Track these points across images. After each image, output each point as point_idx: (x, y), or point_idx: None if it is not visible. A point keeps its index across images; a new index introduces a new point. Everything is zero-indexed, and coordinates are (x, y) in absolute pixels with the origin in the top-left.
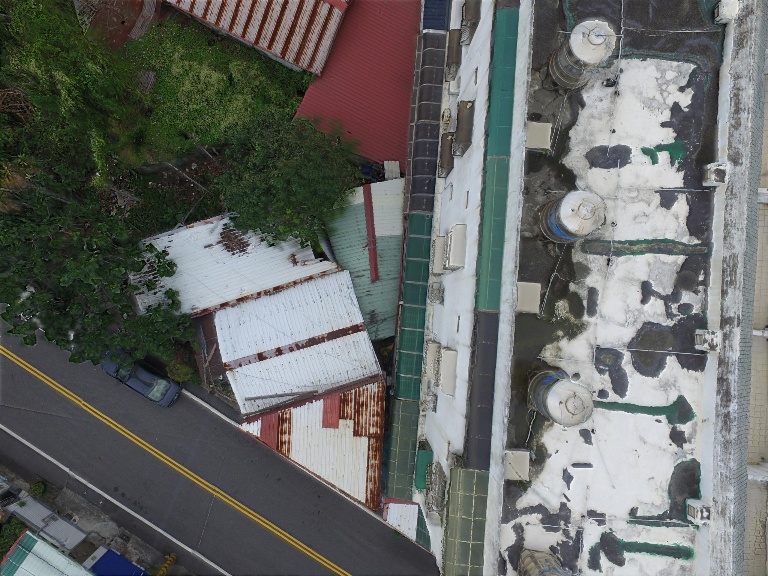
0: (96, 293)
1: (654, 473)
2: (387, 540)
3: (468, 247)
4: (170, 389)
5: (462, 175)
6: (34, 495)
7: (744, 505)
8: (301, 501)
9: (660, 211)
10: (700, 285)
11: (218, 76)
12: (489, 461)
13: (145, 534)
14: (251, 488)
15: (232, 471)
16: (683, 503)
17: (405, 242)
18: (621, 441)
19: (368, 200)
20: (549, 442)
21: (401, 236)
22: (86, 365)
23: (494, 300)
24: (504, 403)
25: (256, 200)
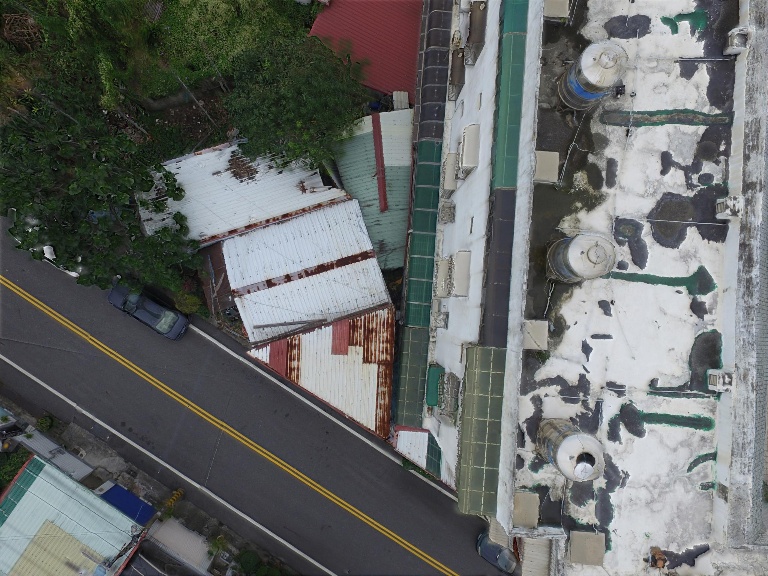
0: (105, 205)
1: (674, 344)
2: (396, 477)
3: (482, 143)
4: (178, 321)
5: (474, 82)
6: (41, 428)
7: (766, 378)
8: (309, 437)
9: (680, 81)
10: (721, 155)
11: (226, 6)
12: (506, 338)
13: (152, 469)
14: (259, 424)
15: (240, 407)
16: (704, 374)
17: (414, 173)
18: (641, 312)
19: (377, 129)
20: (568, 314)
21: (410, 167)
22: (93, 300)
23: (511, 176)
24: (523, 270)
25: (266, 111)
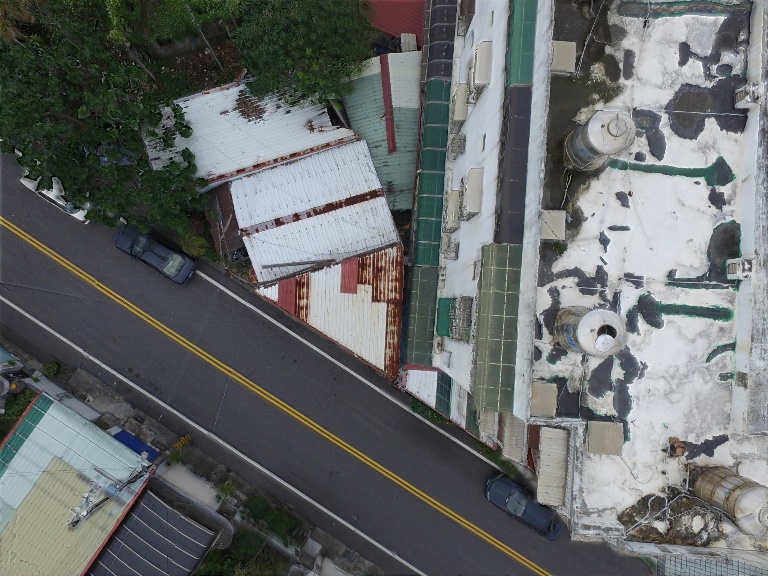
0: (114, 131)
1: (693, 235)
2: (404, 423)
3: (495, 56)
4: (185, 265)
5: (486, 4)
6: (48, 373)
7: None
8: (317, 383)
9: None
10: (739, 46)
11: None
12: (522, 234)
13: None
14: (267, 370)
15: (247, 353)
16: (723, 265)
17: (422, 114)
18: (659, 203)
19: (385, 69)
20: (585, 205)
21: (418, 109)
22: (100, 245)
23: (527, 71)
24: (540, 157)
25: (276, 37)
